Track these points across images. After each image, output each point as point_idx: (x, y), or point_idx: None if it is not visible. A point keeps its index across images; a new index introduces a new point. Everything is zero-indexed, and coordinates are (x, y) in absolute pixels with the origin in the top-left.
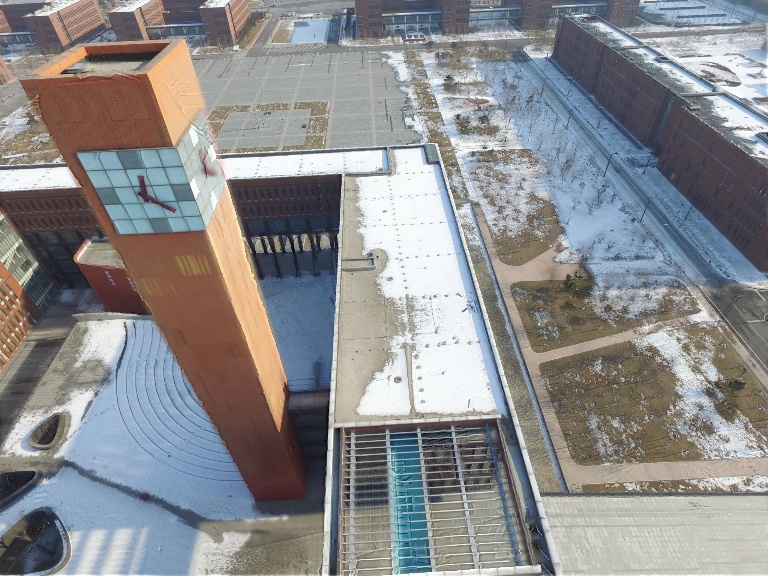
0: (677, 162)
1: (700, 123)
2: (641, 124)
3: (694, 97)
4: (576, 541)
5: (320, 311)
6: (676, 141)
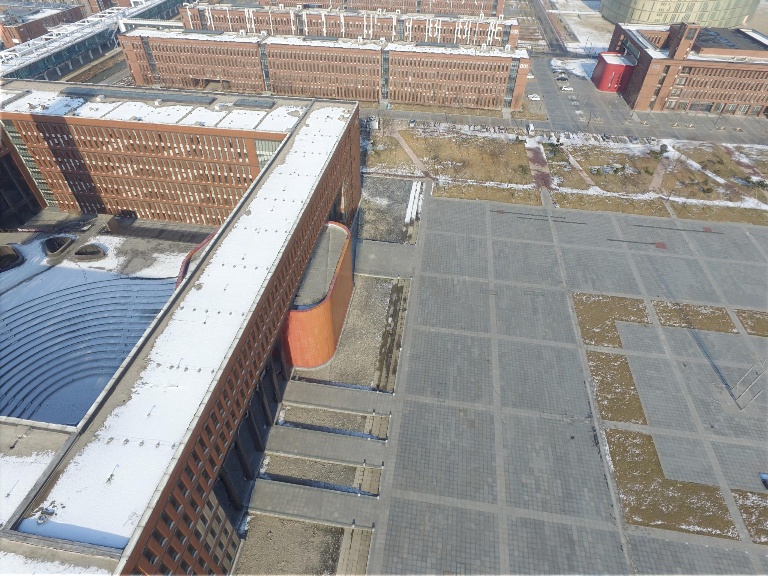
0: None
1: None
2: None
3: None
4: None
5: None
6: None
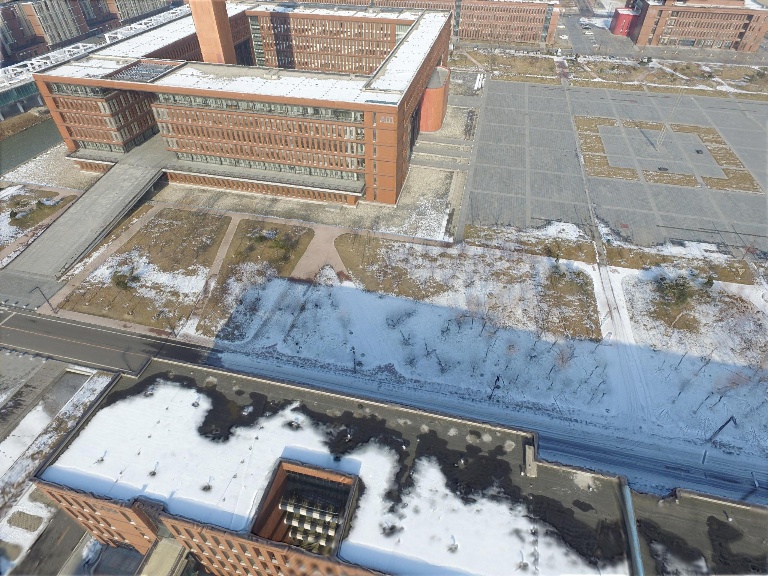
0: None
1: None
2: None
3: (622, 529)
4: (131, 178)
5: None
6: None
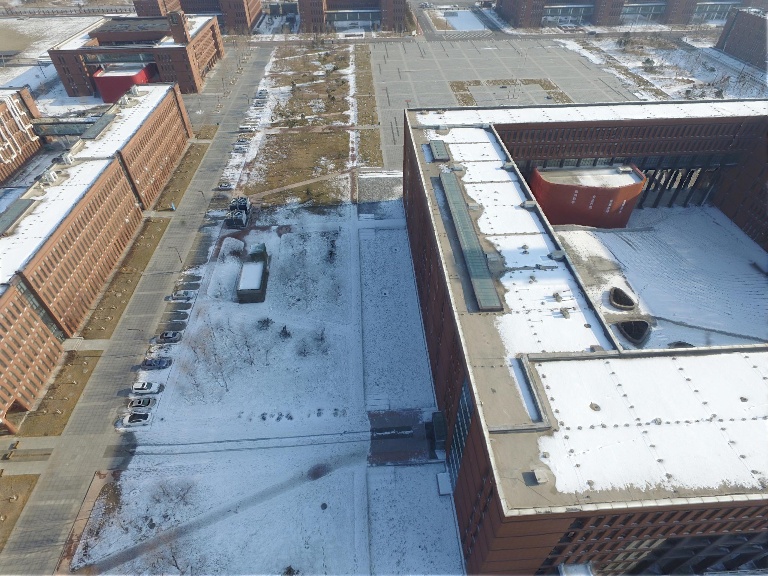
0: None
1: None
2: None
3: None
4: None
5: (715, 231)
6: None
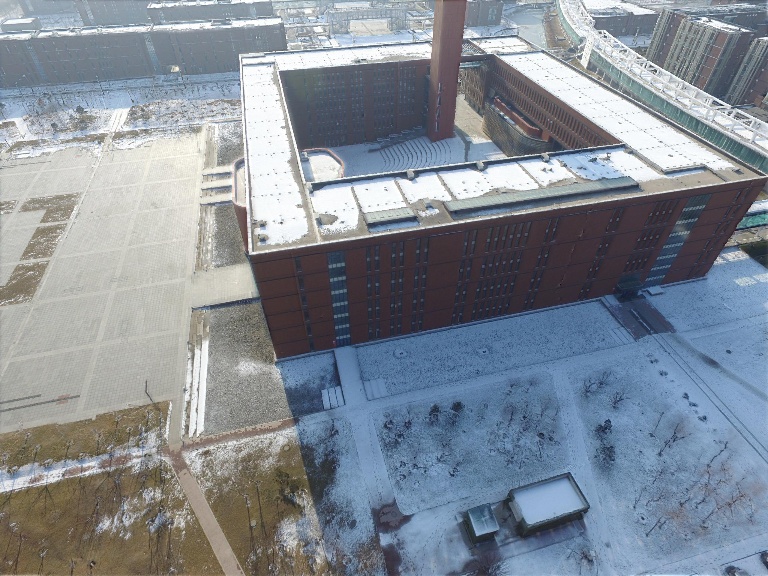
0: (196, 61)
1: (192, 31)
2: (133, 66)
3: None
4: None
5: None
6: (183, 51)
